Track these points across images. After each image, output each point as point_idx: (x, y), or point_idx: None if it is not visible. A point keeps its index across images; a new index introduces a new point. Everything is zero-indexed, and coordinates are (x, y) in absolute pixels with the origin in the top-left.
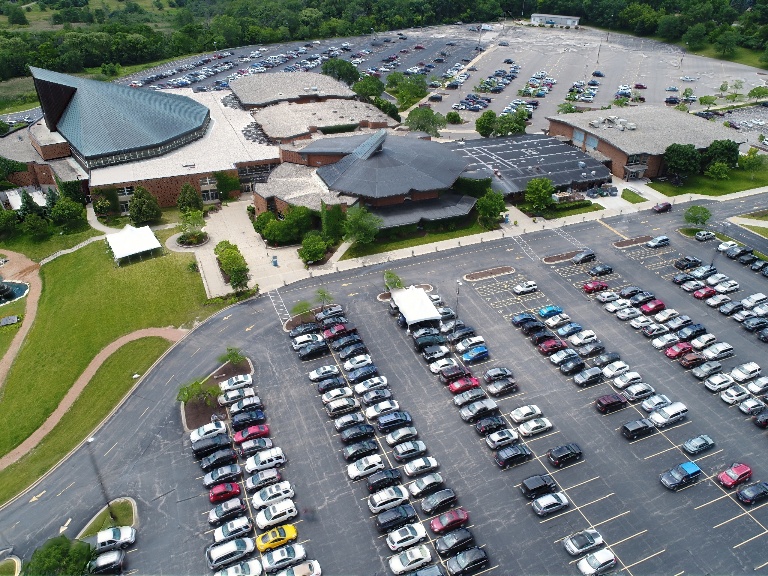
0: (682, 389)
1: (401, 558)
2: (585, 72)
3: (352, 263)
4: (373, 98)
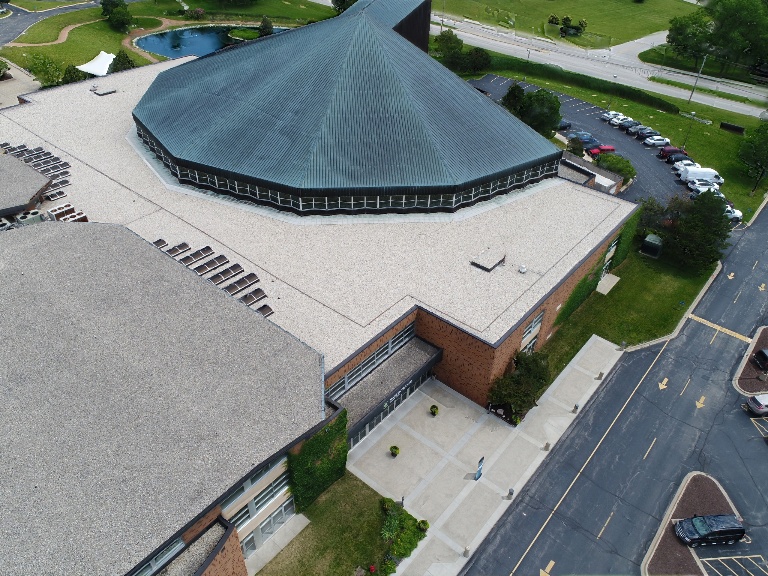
0: None
1: None
2: None
3: None
4: None
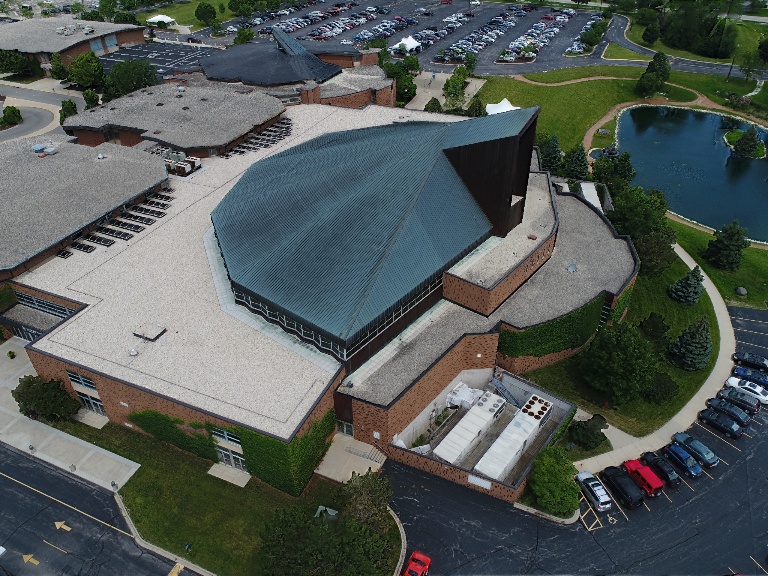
0: (369, 26)
1: (500, 32)
2: None
3: None
4: None
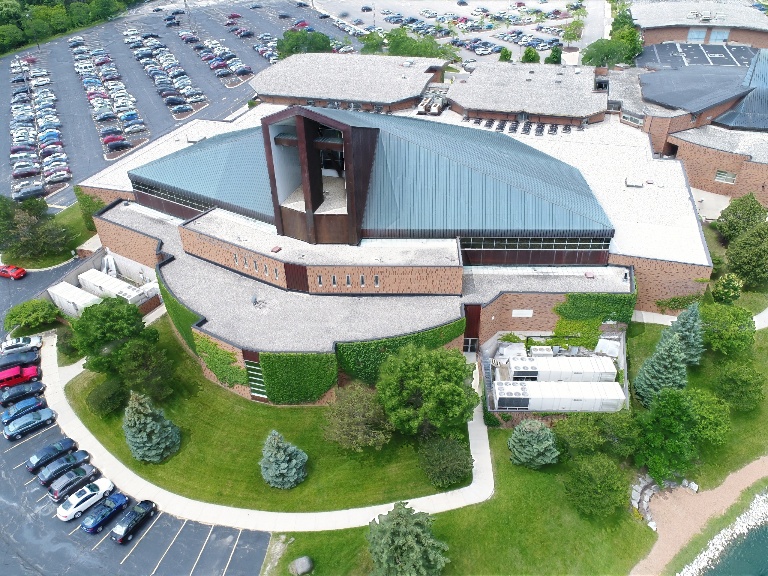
0: None
1: None
2: (445, 4)
3: None
4: None
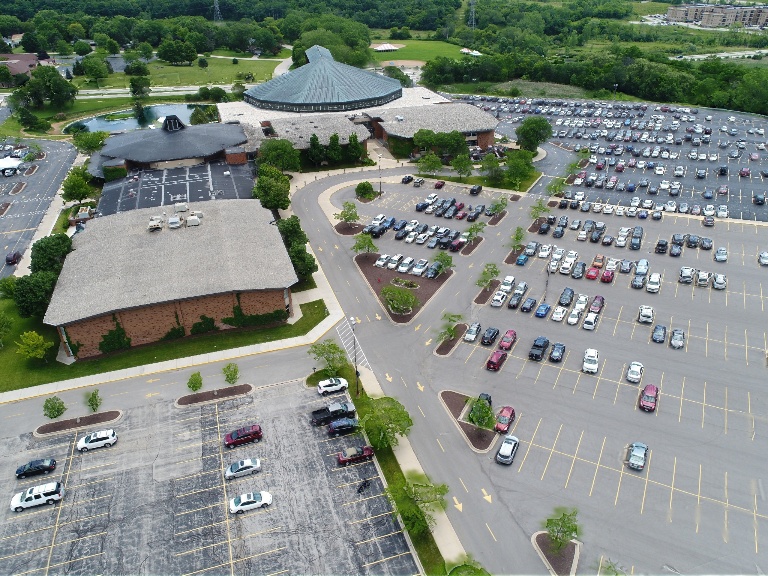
0: None
1: None
2: None
3: (80, 160)
4: (480, 165)
